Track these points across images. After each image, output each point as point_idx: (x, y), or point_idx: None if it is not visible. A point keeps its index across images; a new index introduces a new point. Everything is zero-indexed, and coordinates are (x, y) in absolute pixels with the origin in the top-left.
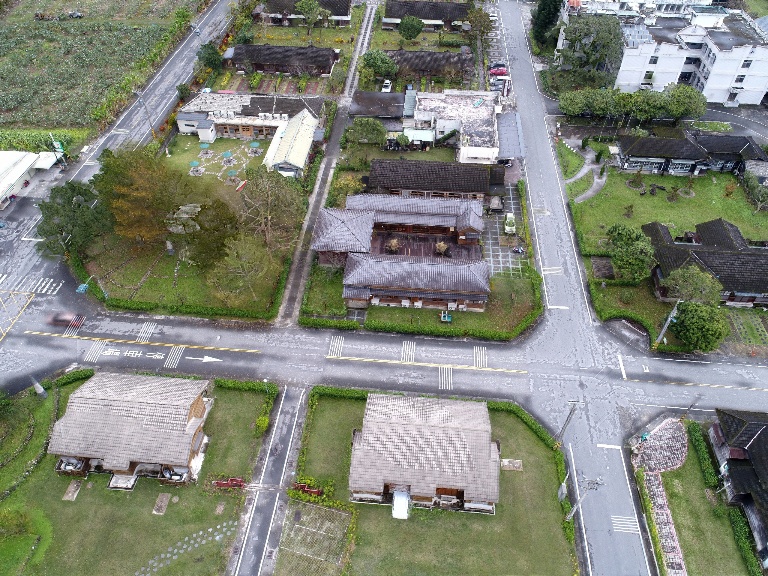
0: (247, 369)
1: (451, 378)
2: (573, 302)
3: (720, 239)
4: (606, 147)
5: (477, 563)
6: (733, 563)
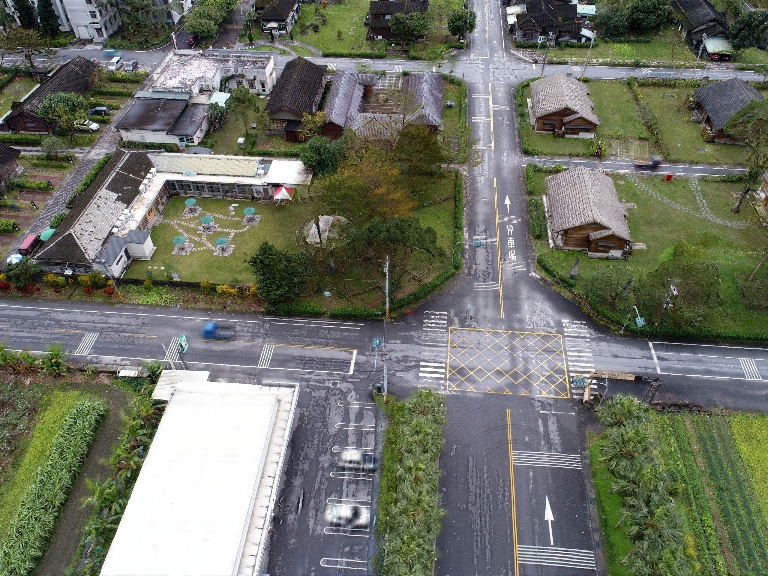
0: (513, 182)
1: (500, 106)
2: (429, 65)
3: (388, 6)
4: (252, 35)
5: (613, 104)
6: (583, 50)
